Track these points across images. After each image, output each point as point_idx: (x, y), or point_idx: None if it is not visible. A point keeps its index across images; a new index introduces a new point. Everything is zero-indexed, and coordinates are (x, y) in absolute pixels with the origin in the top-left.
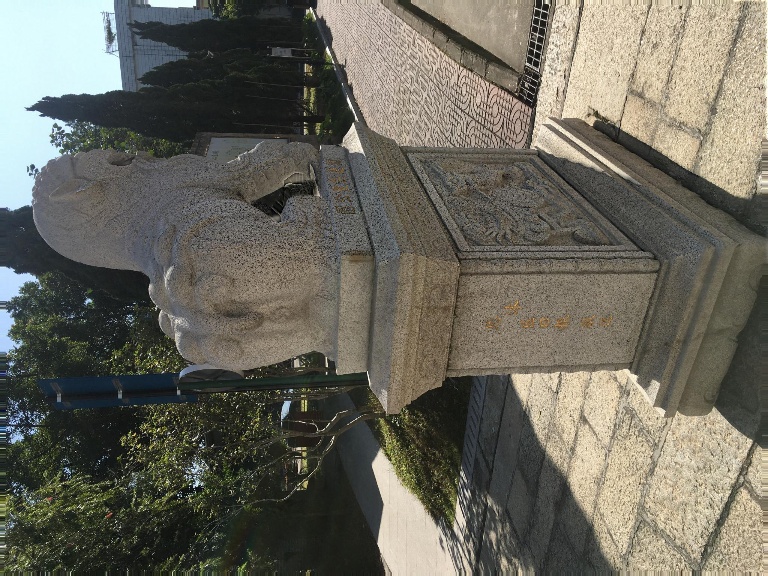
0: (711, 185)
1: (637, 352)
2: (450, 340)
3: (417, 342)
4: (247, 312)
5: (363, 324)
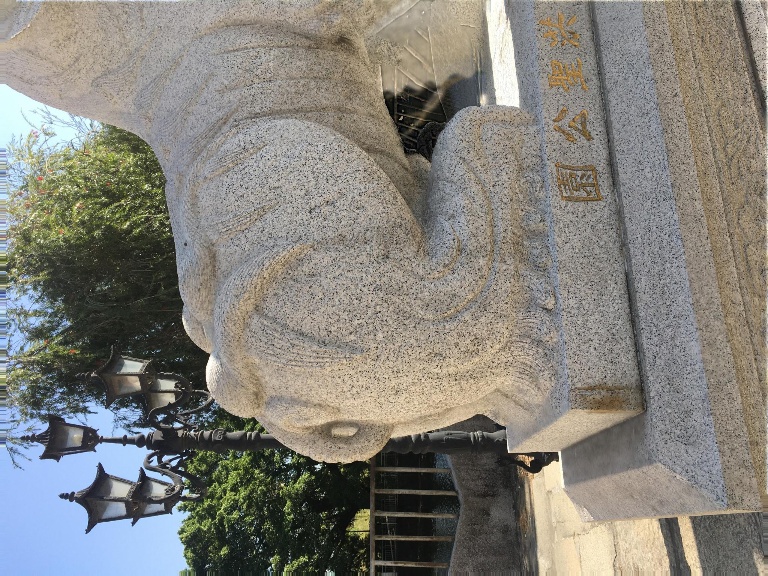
0: None
1: None
2: None
3: None
4: (364, 425)
5: (576, 436)
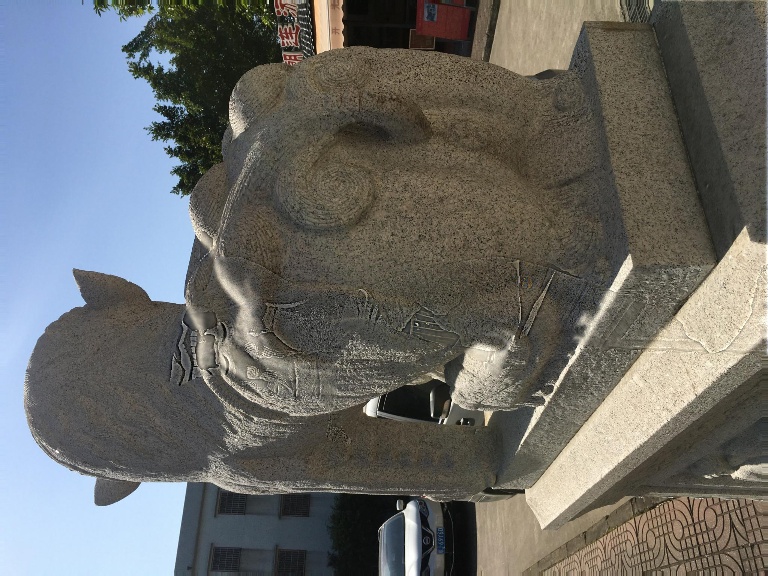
0: None
1: None
2: None
3: None
4: None
5: (667, 143)
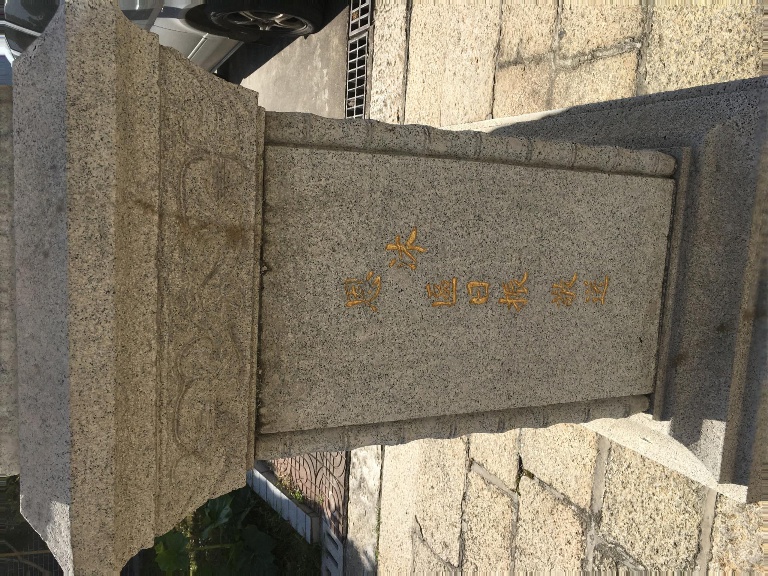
0: None
1: (659, 366)
2: (257, 341)
3: (155, 329)
4: None
5: None
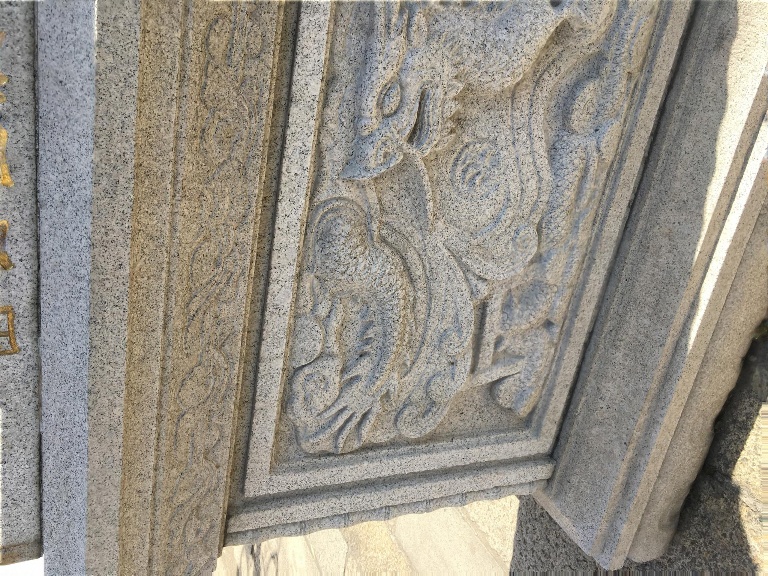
0: (765, 392)
1: None
2: None
3: None
4: None
5: None
